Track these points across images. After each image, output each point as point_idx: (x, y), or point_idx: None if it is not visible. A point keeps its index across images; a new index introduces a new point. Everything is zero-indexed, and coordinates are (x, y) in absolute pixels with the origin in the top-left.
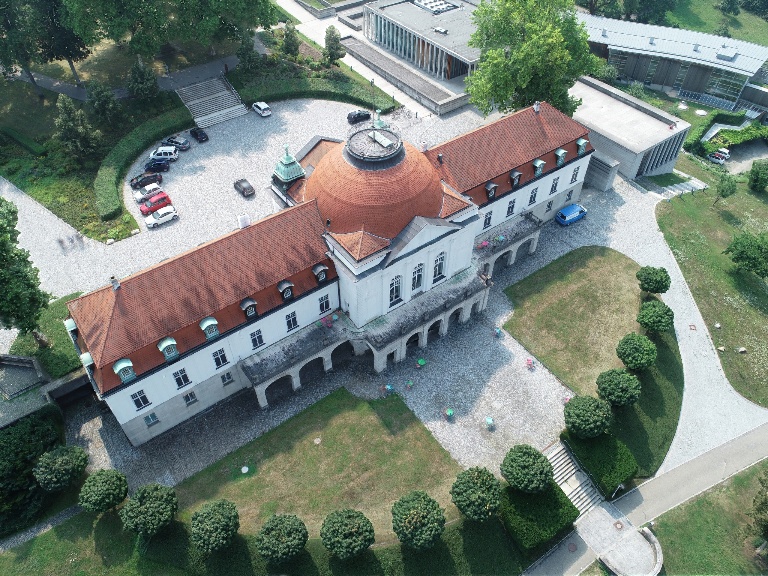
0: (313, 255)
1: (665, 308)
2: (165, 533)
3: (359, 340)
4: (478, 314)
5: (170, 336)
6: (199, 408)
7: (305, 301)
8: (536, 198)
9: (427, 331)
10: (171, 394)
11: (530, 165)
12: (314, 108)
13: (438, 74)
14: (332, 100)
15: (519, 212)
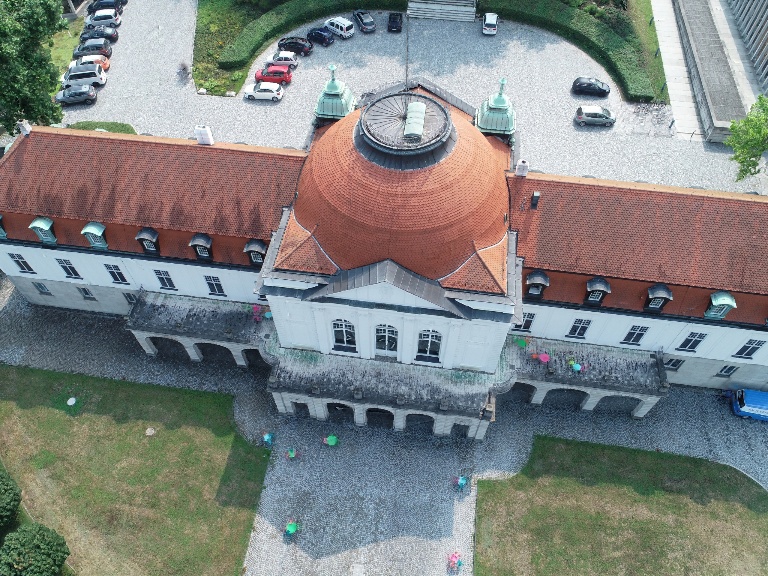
0: (256, 225)
1: None
2: None
3: (266, 361)
4: (467, 438)
5: (51, 218)
6: (102, 308)
7: (232, 273)
8: (699, 347)
9: (363, 411)
10: (61, 277)
11: (705, 294)
12: (552, 51)
13: (765, 82)
14: (585, 51)
15: (653, 349)
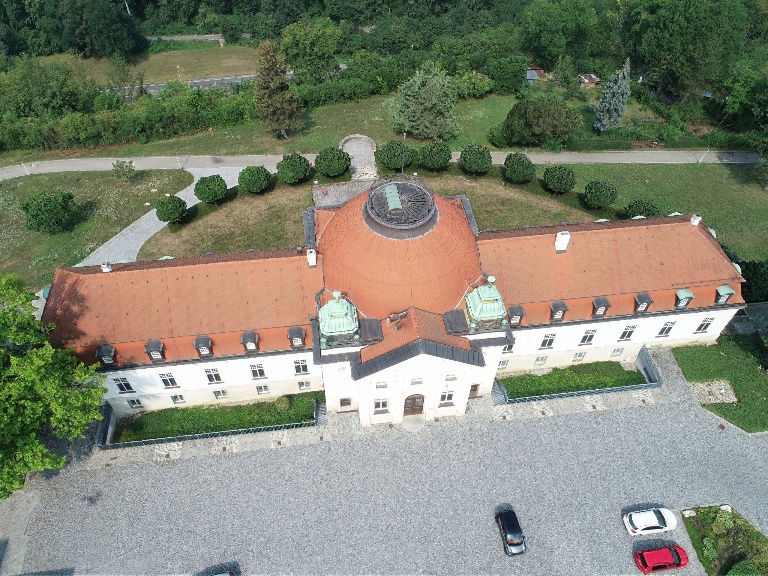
0: None
1: (203, 181)
2: None
3: None
4: None
5: None
6: None
7: None
8: None
9: None
10: None
11: None
12: None
13: None
14: None
15: None
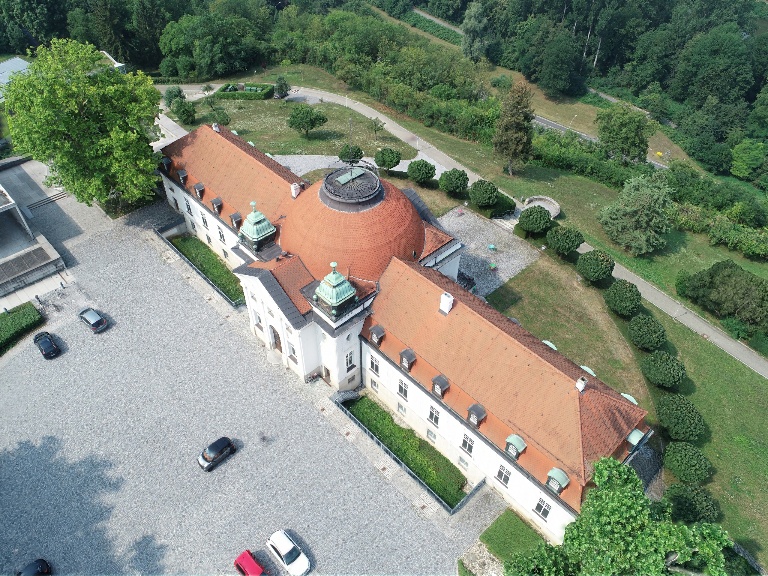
0: None
1: (385, 150)
2: None
3: None
4: None
5: None
6: None
7: None
8: None
9: None
10: None
11: None
12: None
13: None
14: None
15: None
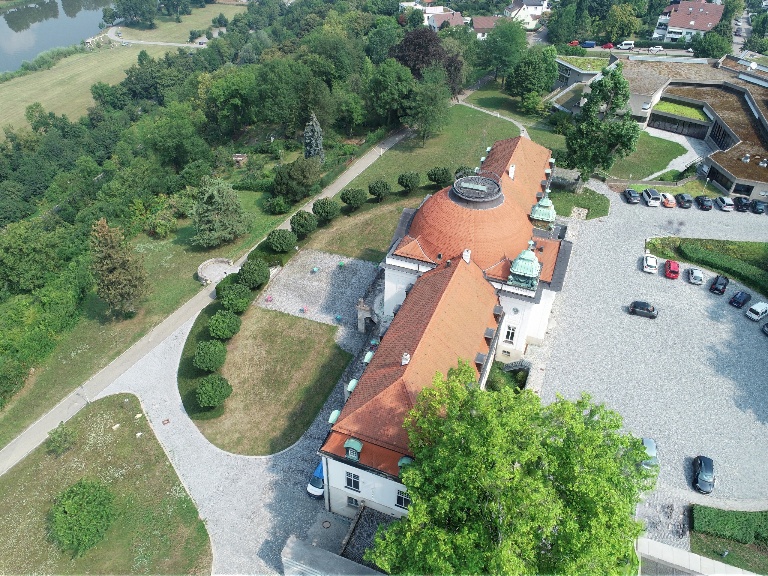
0: None
1: (204, 352)
2: (432, 187)
3: None
4: None
5: None
6: None
7: None
8: None
9: None
10: None
11: None
12: None
13: None
14: None
15: None
